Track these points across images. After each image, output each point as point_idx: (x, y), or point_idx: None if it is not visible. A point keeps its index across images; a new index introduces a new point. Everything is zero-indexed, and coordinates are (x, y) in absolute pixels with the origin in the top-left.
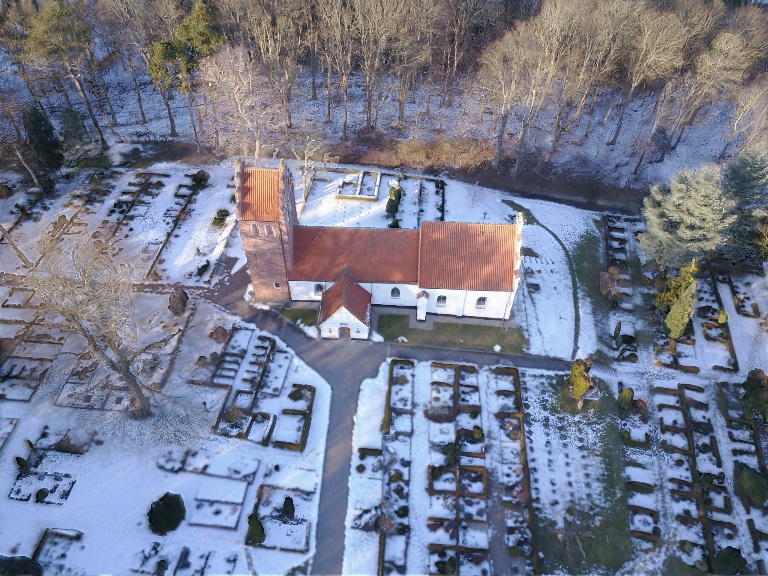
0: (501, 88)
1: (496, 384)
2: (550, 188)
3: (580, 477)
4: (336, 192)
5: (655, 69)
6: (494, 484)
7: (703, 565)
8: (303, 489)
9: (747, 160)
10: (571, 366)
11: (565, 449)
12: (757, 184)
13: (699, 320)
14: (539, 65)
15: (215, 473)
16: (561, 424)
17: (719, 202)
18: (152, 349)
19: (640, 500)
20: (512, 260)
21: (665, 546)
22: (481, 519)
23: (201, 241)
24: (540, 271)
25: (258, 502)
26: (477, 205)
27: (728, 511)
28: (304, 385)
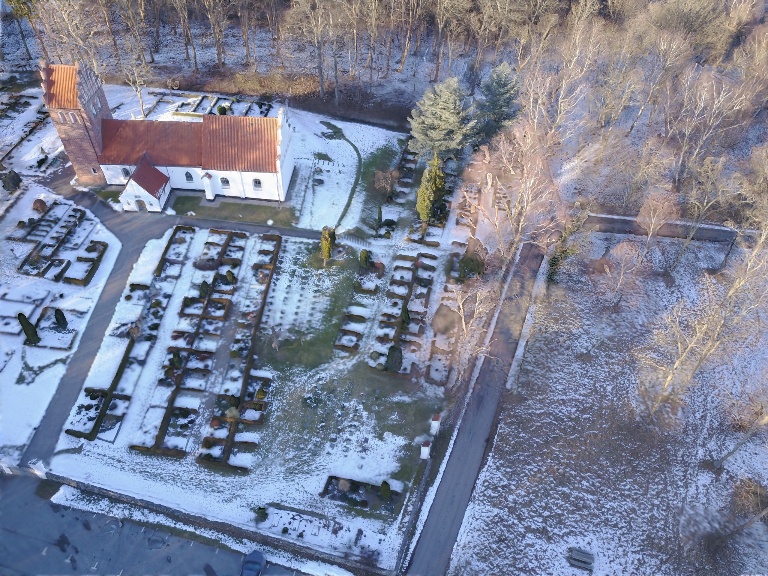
0: (310, 22)
1: (260, 246)
2: (367, 114)
3: (306, 309)
4: (173, 110)
5: (453, 11)
6: (234, 312)
7: (379, 365)
8: (78, 310)
9: (493, 77)
10: None
11: (301, 291)
12: (502, 97)
13: (457, 211)
14: (353, 7)
15: (12, 299)
16: (305, 275)
17: (454, 106)
18: None
19: (352, 327)
20: (275, 147)
21: (358, 355)
22: (215, 333)
23: (49, 144)
24: (329, 171)
25: (40, 317)
26: (292, 122)
27: (419, 335)
28: (98, 241)
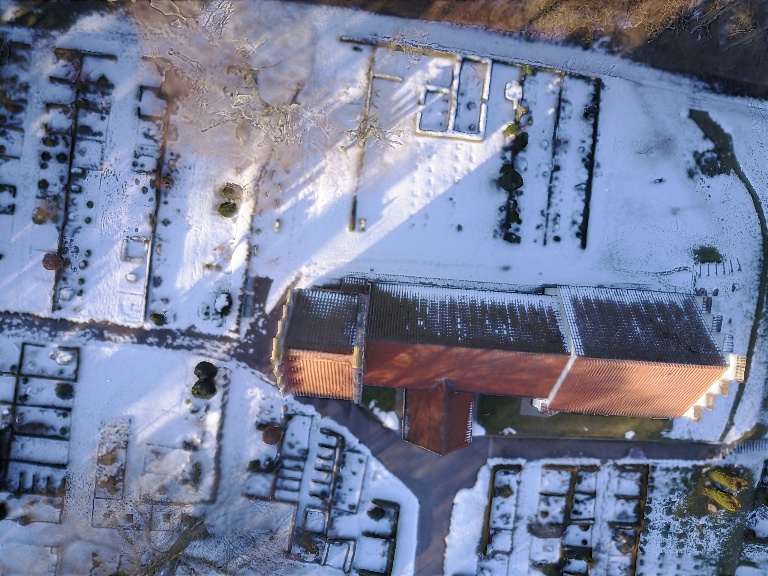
0: None
1: (618, 485)
2: None
3: None
4: (414, 120)
5: None
6: None
7: None
8: None
9: None
10: (716, 452)
11: (678, 560)
12: None
13: None
14: None
15: None
16: (682, 530)
17: None
18: (187, 451)
19: None
20: (698, 397)
21: None
22: None
23: (207, 236)
24: (717, 291)
25: None
26: None
27: None
28: (386, 506)
